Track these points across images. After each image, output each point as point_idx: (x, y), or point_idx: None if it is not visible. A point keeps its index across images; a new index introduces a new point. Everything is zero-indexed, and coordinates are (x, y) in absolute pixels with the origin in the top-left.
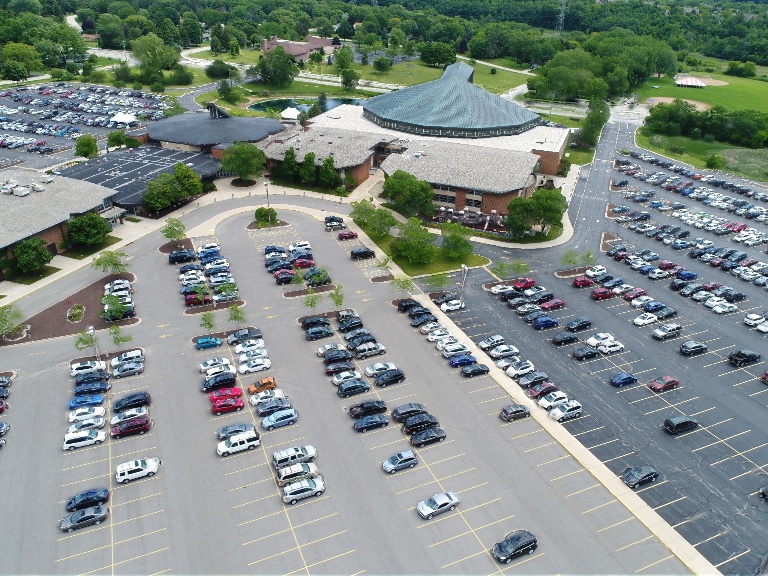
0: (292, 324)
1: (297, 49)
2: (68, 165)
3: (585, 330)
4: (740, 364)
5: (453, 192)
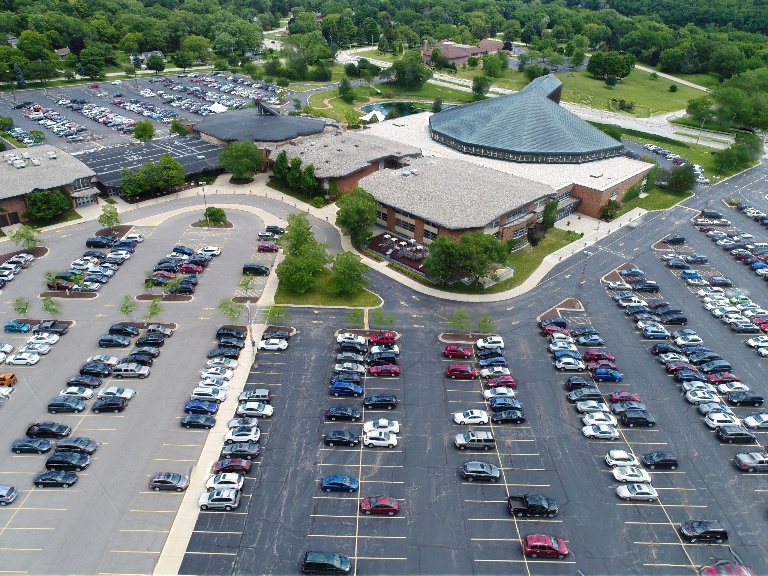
0: (107, 327)
1: (456, 52)
2: (120, 145)
3: (384, 410)
4: (516, 513)
5: (413, 220)
